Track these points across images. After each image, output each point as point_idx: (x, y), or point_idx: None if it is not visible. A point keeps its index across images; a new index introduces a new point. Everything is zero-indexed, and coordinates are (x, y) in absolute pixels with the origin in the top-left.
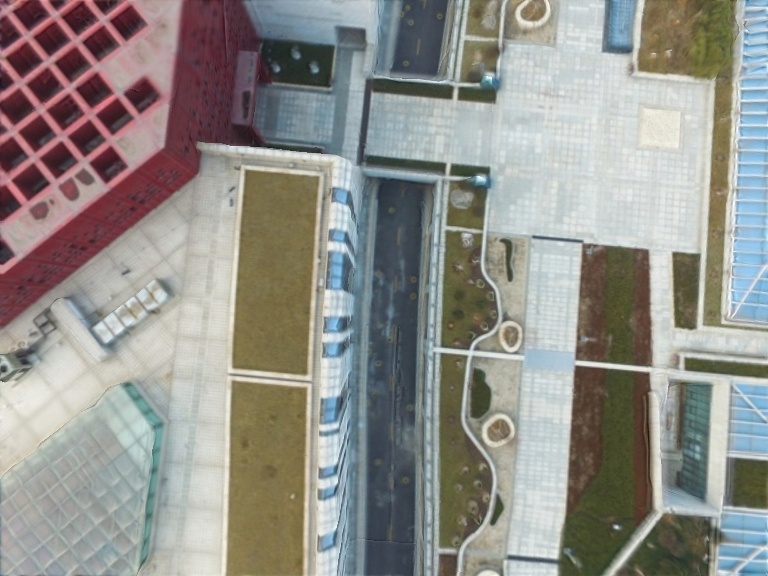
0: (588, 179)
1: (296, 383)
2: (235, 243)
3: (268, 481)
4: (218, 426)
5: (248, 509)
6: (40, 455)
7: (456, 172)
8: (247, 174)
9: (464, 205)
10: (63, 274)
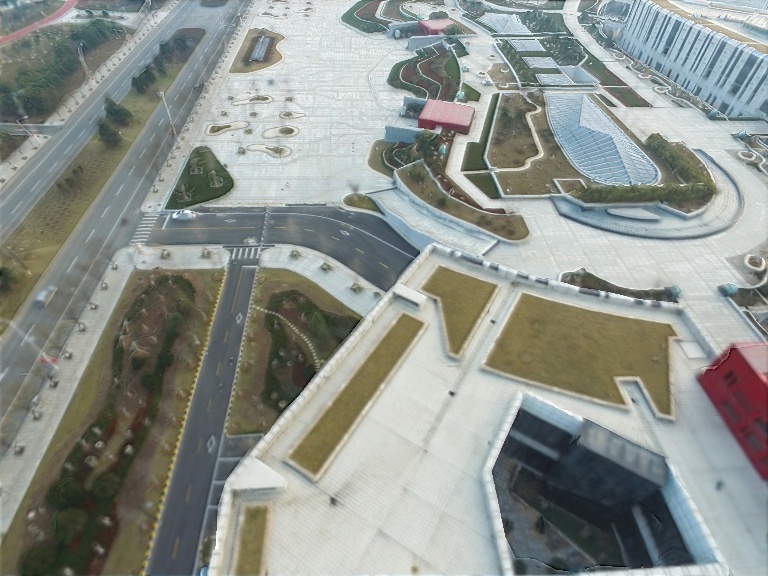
0: None
1: None
2: None
3: None
4: None
5: None
6: None
7: (723, 118)
8: None
9: None
10: None
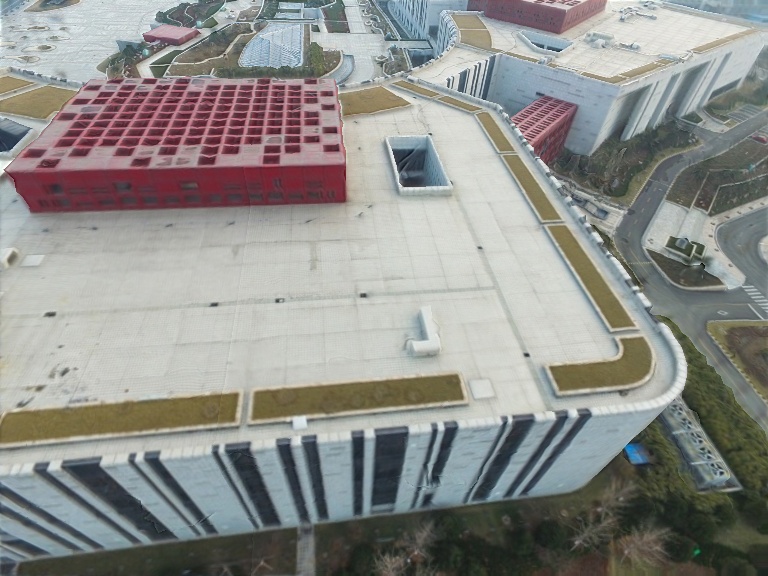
0: None
1: None
2: None
3: None
4: None
5: None
6: None
7: (396, 39)
8: None
9: None
10: None
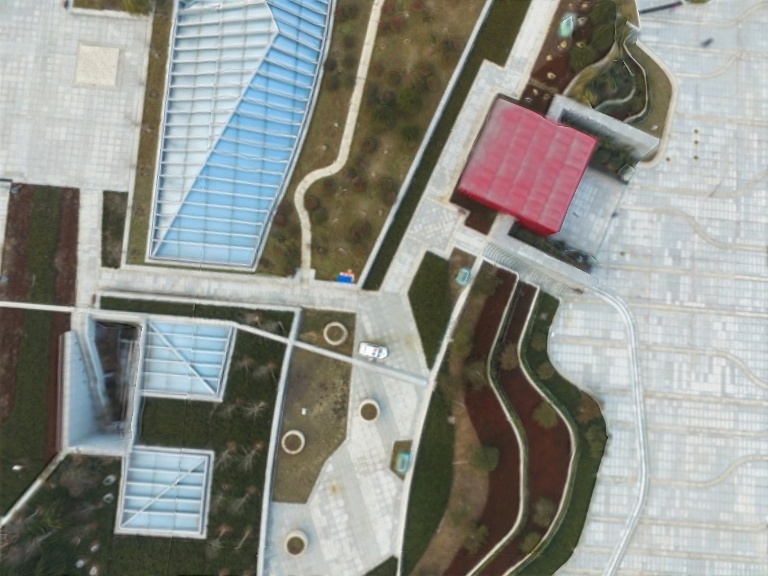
0: (21, 118)
1: None
2: None
3: None
4: None
5: None
6: None
7: None
8: None
9: None
10: None
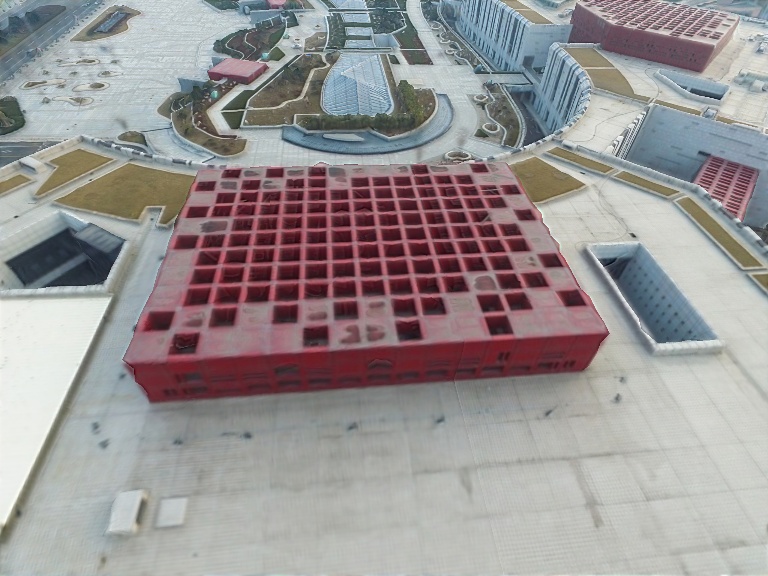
0: None
1: None
2: None
3: (513, 3)
4: None
5: None
6: None
7: (487, 72)
8: None
9: None
10: None
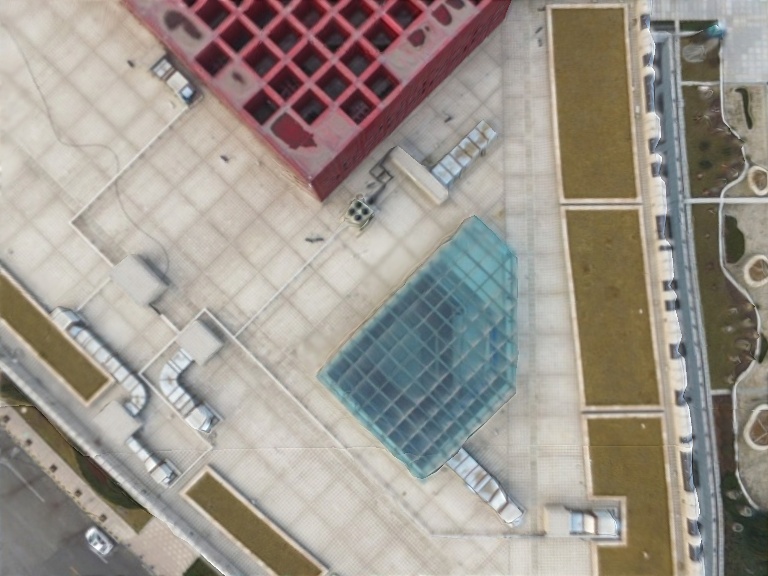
0: None
1: (627, 206)
2: (551, 80)
3: (612, 301)
4: (557, 255)
5: (597, 329)
6: (409, 289)
7: (686, 28)
8: (553, 13)
9: (700, 58)
10: (396, 123)
